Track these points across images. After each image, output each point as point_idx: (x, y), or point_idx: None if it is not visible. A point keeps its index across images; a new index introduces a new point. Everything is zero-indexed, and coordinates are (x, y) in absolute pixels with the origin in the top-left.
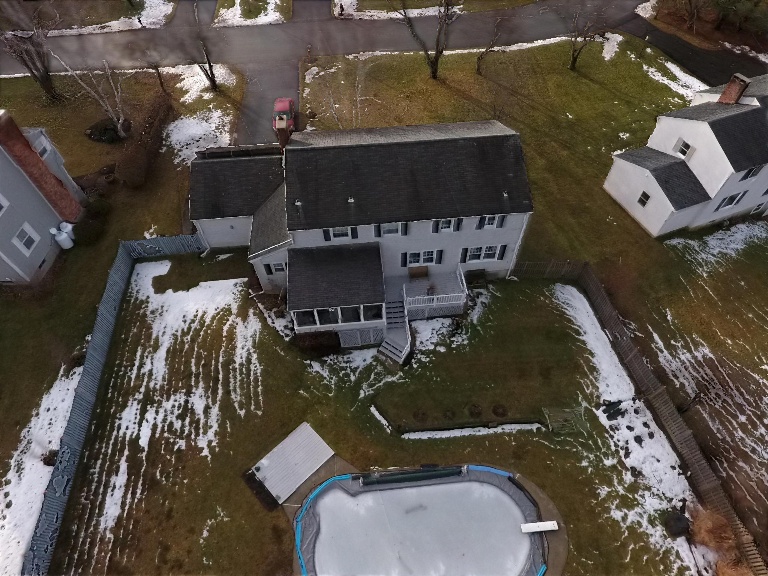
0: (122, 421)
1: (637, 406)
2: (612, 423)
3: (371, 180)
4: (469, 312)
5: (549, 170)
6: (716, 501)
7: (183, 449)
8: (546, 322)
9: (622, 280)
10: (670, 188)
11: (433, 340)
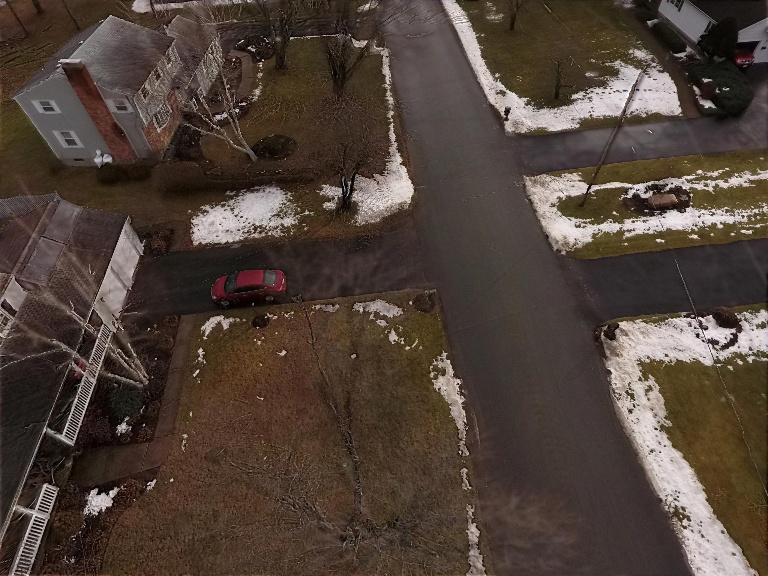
0: None
1: None
2: None
3: None
4: None
5: None
6: None
7: None
8: None
9: None
10: None
11: None
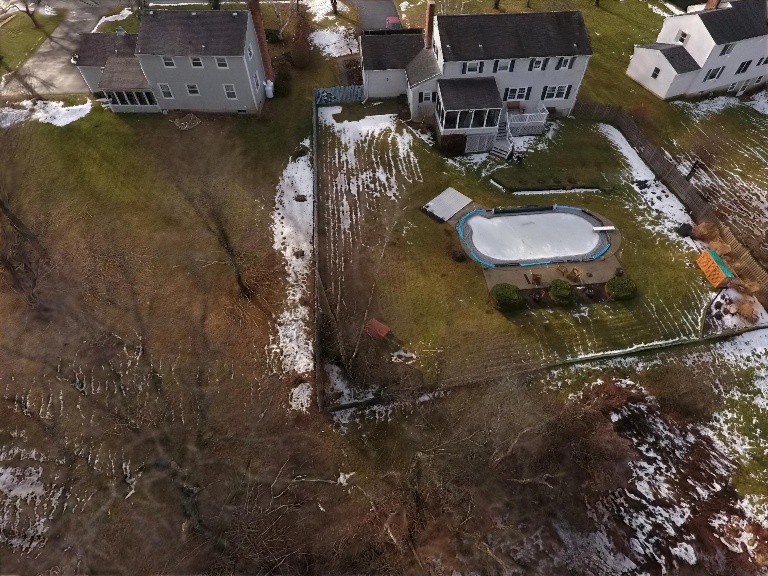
0: (337, 183)
1: (657, 183)
2: (642, 190)
3: (492, 35)
4: (546, 133)
5: None
6: (708, 219)
7: (379, 196)
8: (596, 141)
9: (643, 123)
10: (674, 61)
11: (525, 146)
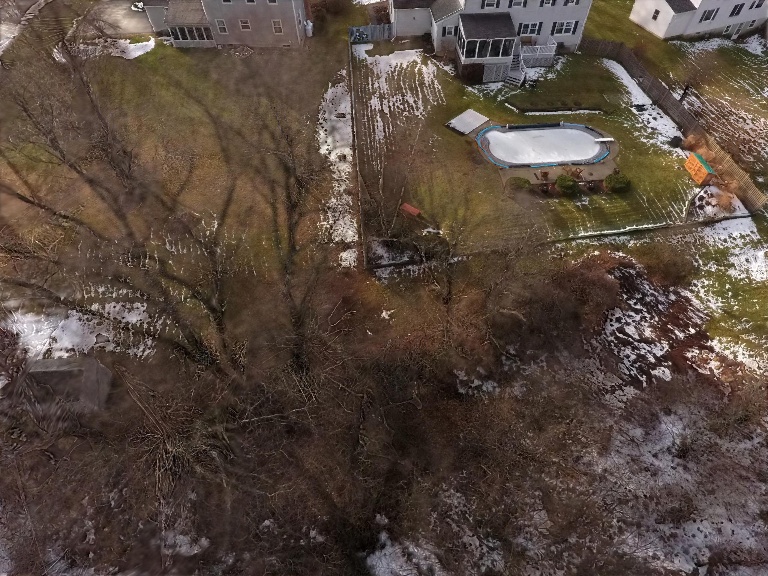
0: (372, 104)
1: (653, 107)
2: (640, 113)
3: None
4: (555, 65)
5: (594, 11)
6: (696, 133)
7: None
8: (599, 73)
9: (643, 60)
10: (672, 2)
11: (536, 76)
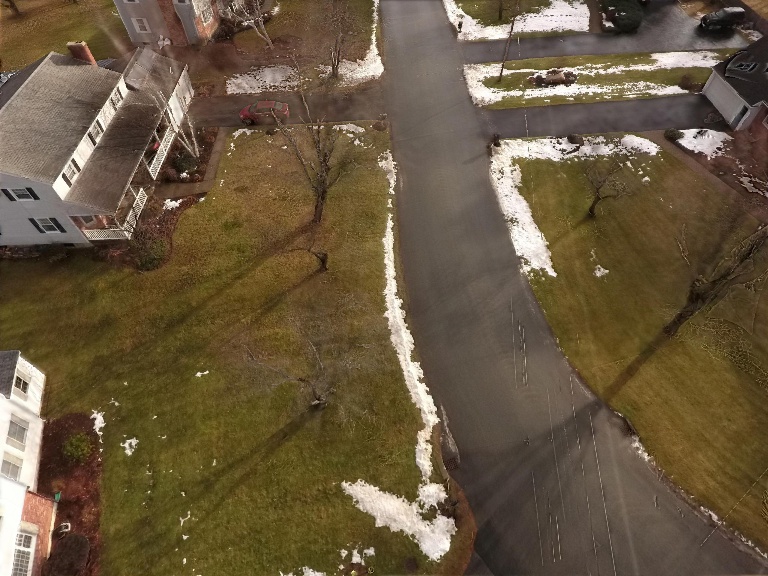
0: None
1: None
2: None
3: (3, 96)
4: None
5: (105, 321)
6: None
7: None
8: None
9: None
10: None
11: None
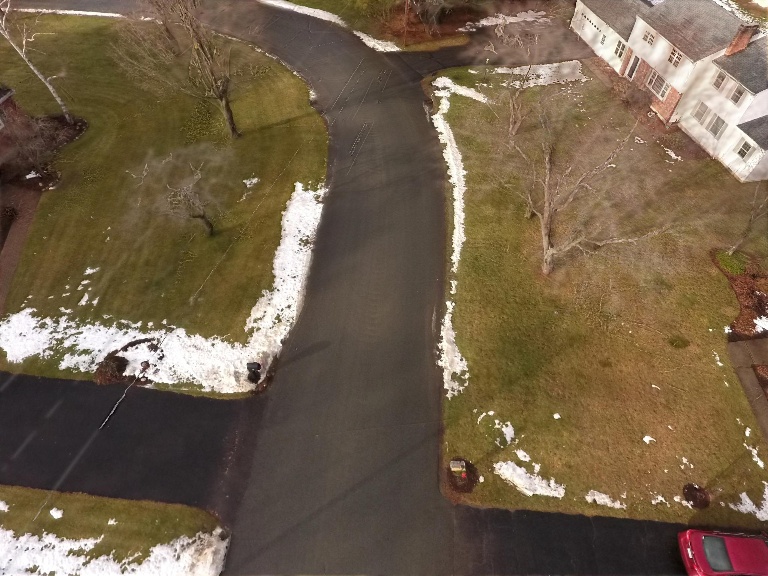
0: None
1: None
2: None
3: None
4: None
5: (729, 212)
6: None
7: None
8: None
9: None
10: None
11: None
